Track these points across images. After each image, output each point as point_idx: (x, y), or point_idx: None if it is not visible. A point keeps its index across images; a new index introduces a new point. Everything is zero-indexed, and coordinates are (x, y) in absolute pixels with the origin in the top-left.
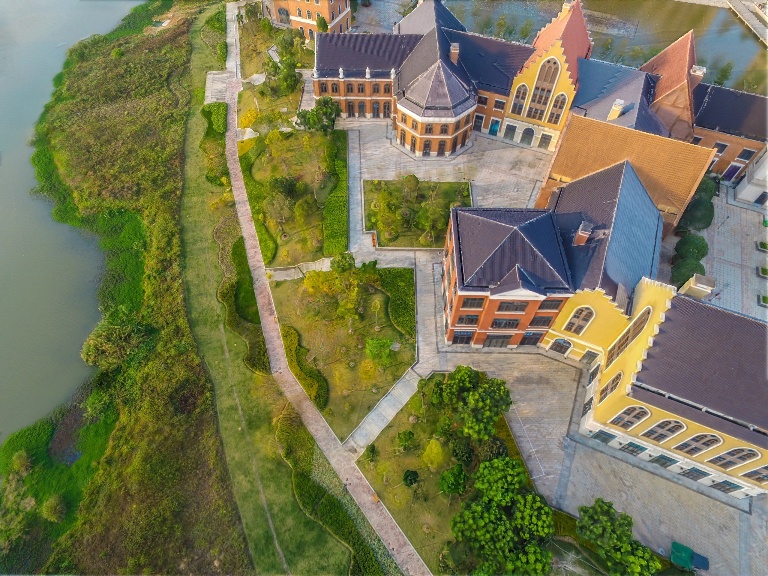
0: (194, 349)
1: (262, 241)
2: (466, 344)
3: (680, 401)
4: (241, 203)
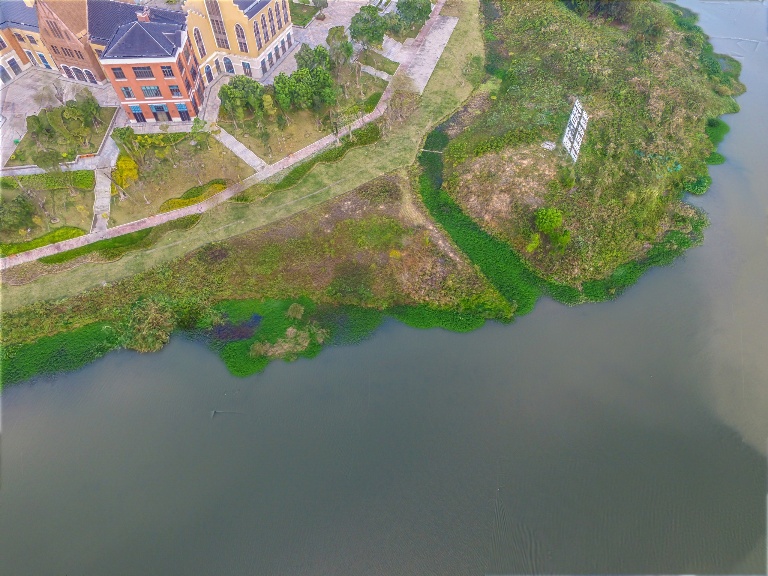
0: None
1: (53, 240)
2: (198, 113)
3: (253, 6)
4: None
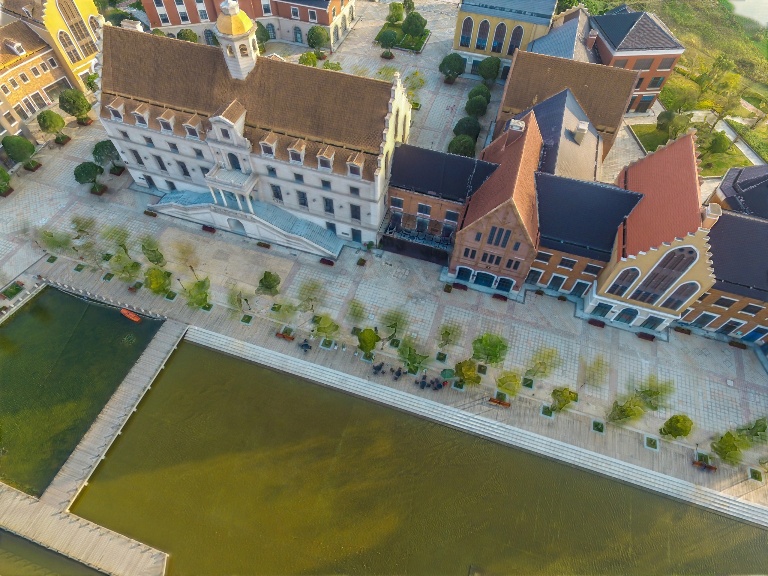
0: (765, 82)
1: None
2: None
3: None
4: None
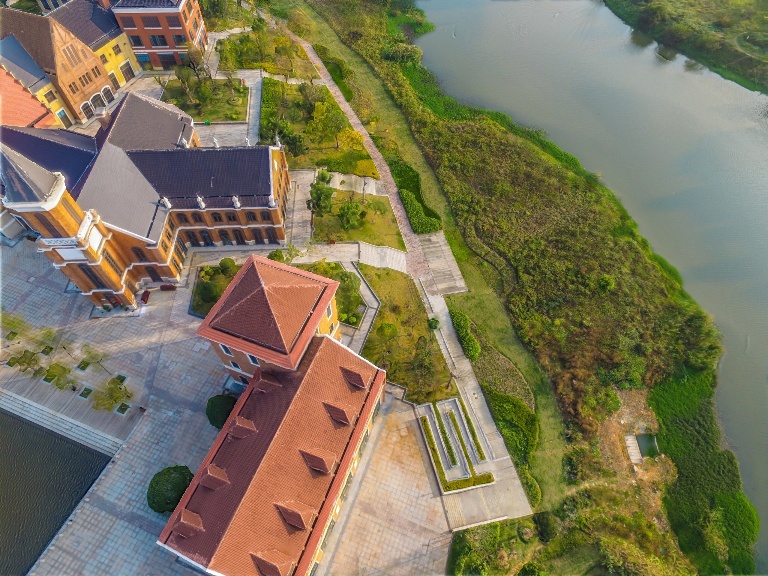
0: None
1: None
2: None
3: None
4: (357, 124)
